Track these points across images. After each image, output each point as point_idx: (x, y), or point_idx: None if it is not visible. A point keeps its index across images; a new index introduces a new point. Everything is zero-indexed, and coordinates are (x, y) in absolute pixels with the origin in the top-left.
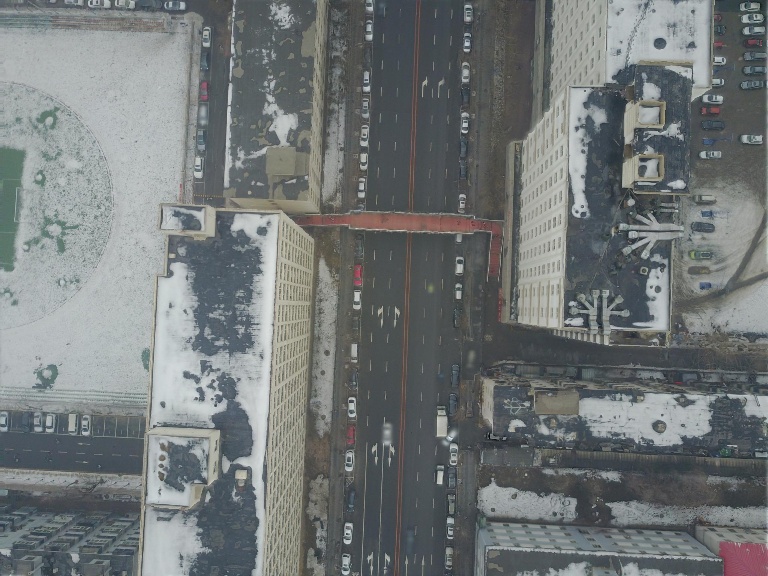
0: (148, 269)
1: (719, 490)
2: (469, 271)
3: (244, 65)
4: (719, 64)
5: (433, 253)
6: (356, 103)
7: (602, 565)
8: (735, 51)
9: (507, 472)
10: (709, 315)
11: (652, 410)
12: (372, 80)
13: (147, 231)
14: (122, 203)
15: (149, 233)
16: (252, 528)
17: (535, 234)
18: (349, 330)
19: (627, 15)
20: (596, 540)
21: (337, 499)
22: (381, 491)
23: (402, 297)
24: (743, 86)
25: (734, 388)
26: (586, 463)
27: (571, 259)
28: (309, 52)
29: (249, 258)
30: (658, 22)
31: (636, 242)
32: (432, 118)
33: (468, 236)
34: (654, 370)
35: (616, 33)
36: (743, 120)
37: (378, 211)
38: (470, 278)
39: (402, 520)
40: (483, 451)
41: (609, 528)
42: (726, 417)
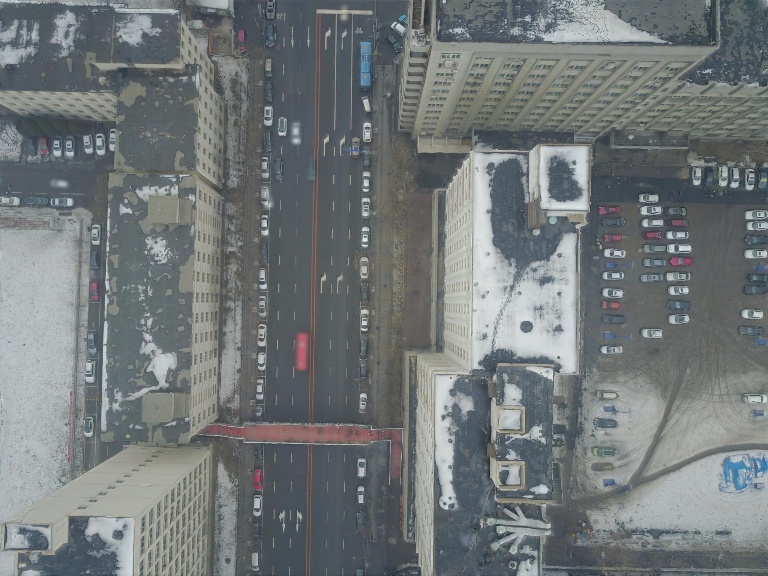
0: (40, 478)
1: None
2: (371, 472)
3: (119, 302)
4: (619, 257)
5: (335, 454)
6: (253, 301)
7: None
8: (635, 242)
9: None
10: (613, 512)
11: None
12: (269, 276)
13: (38, 439)
14: (11, 410)
15: (40, 441)
16: None
17: (421, 477)
18: (250, 537)
19: (493, 298)
20: None
21: None
22: None
23: (304, 500)
24: (643, 279)
25: None
26: None
27: (439, 553)
28: (187, 288)
29: (105, 564)
30: (524, 304)
31: (504, 537)
32: (331, 314)
33: None
34: (559, 570)
35: (482, 316)
36: (644, 313)
37: (273, 424)
38: (373, 479)
39: None
40: None
41: None
42: None
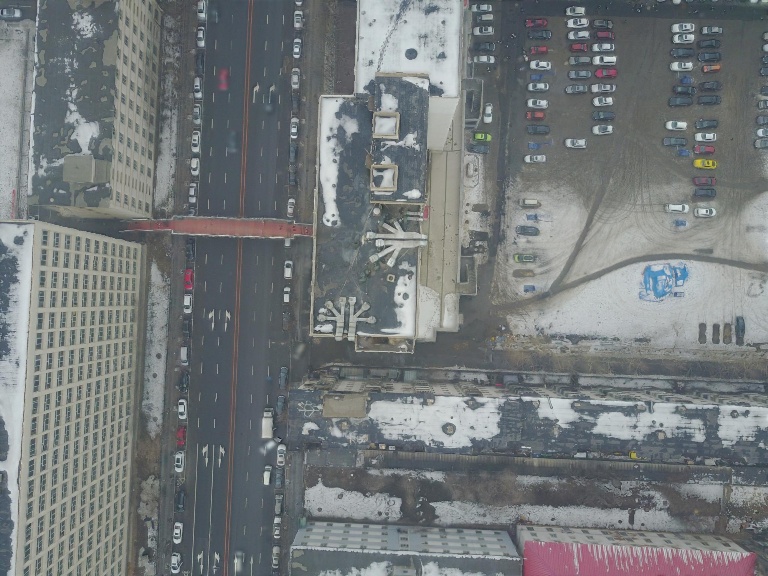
0: None
1: (540, 490)
2: (298, 275)
3: (47, 74)
4: (544, 69)
5: (263, 257)
6: (188, 109)
7: (403, 564)
8: (561, 55)
9: (334, 472)
10: (533, 317)
11: (442, 413)
12: (205, 86)
13: None
14: None
15: None
16: (7, 531)
17: None
18: (180, 333)
19: (379, 26)
20: (408, 539)
21: (168, 499)
22: (211, 491)
23: (233, 301)
24: (568, 90)
25: (550, 390)
26: (408, 464)
27: (322, 267)
28: (111, 61)
29: (6, 267)
30: (409, 33)
31: (382, 250)
32: (263, 123)
33: (298, 240)
34: (478, 372)
35: (368, 44)
36: (568, 124)
37: (200, 216)
38: (299, 282)
39: (231, 520)
40: (306, 452)
41: (431, 527)
42: (515, 419)
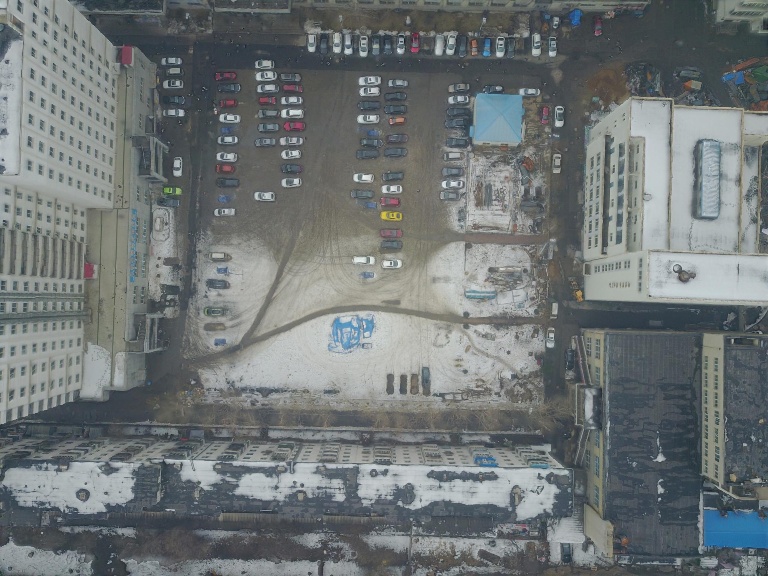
0: None
1: (230, 543)
2: None
3: None
4: (233, 122)
5: None
6: None
7: None
8: (252, 108)
9: (24, 531)
10: (224, 371)
11: (76, 479)
12: None
13: None
14: None
15: None
16: None
17: None
18: None
19: None
20: None
21: None
22: None
23: None
24: (257, 143)
25: None
26: (93, 521)
27: None
28: None
29: None
30: None
31: None
32: None
33: None
34: (169, 426)
35: None
36: (258, 177)
37: None
38: None
39: None
40: None
41: None
42: (150, 484)
